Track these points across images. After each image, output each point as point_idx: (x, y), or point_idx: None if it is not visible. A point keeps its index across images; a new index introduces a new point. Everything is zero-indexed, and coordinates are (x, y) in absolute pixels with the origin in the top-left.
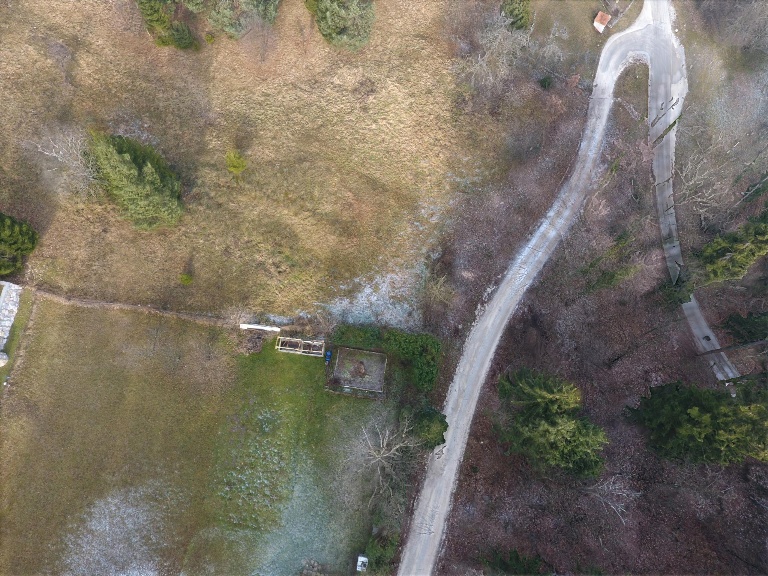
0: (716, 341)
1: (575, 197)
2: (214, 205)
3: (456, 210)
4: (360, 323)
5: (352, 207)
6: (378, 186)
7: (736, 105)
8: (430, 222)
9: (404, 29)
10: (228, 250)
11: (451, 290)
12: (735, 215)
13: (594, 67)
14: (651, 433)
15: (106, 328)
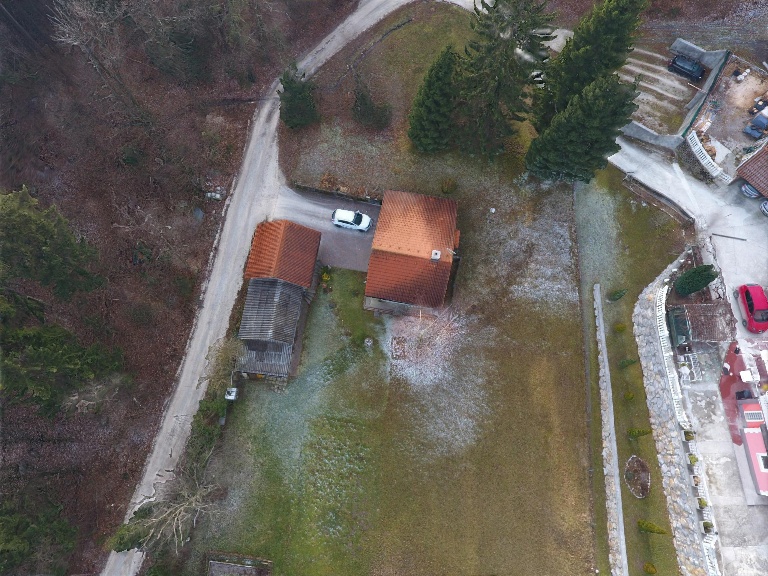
0: None
1: None
2: None
3: None
4: None
5: None
6: None
7: None
8: None
9: None
10: None
11: None
12: None
13: None
14: None
15: None
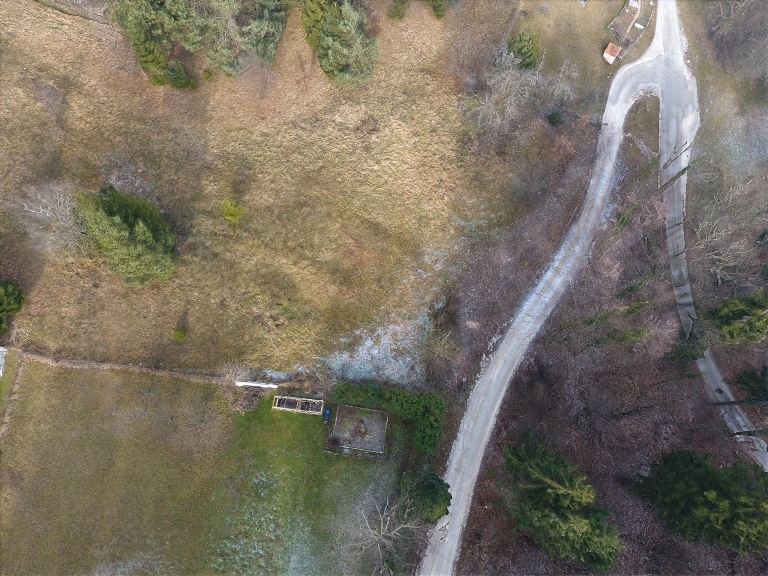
0: (727, 388)
1: (583, 239)
2: (210, 255)
3: (461, 256)
4: (360, 378)
5: (353, 254)
6: (380, 231)
7: (749, 139)
8: (434, 269)
9: (408, 63)
10: (224, 303)
11: (455, 347)
12: (749, 260)
13: (604, 100)
14: (664, 507)
15: (95, 390)
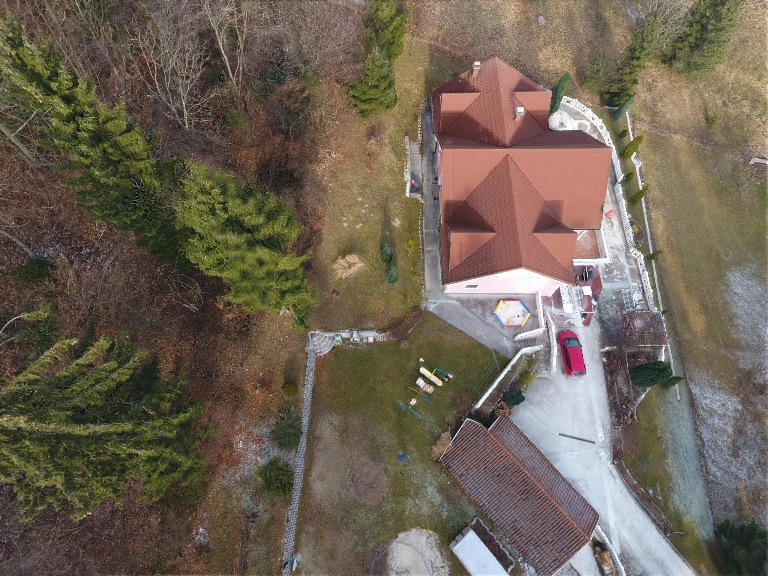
0: None
1: None
2: None
3: None
4: None
5: None
6: None
7: None
8: None
9: None
10: (726, 103)
11: None
12: None
13: None
14: None
15: (678, 153)
